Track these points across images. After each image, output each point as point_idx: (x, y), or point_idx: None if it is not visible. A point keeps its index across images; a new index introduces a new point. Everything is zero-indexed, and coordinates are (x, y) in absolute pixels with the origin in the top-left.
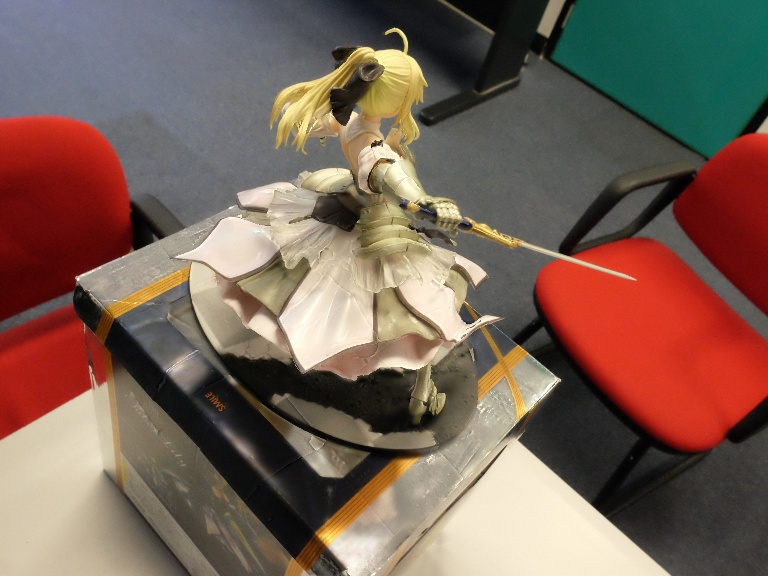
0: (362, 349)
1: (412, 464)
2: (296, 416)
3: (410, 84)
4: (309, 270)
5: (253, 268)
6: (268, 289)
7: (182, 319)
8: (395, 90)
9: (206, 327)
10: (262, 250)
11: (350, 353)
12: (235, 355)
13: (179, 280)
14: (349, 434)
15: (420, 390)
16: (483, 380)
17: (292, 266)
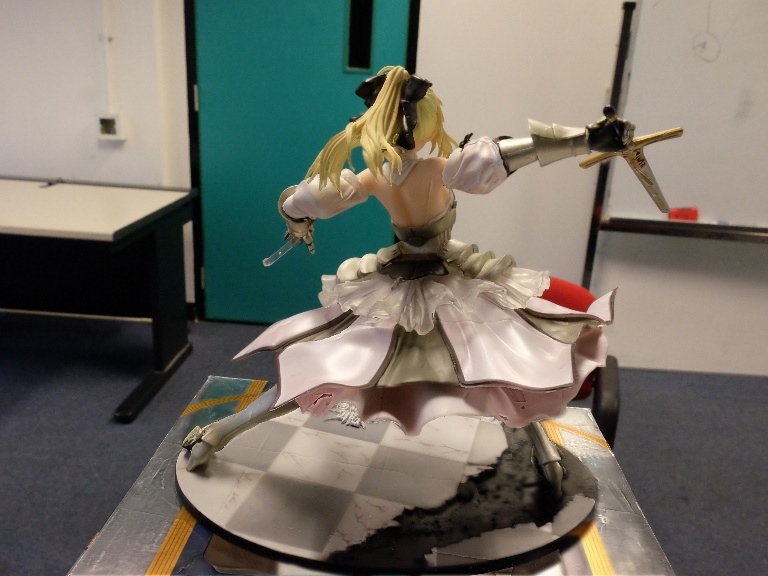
0: (439, 473)
1: (598, 533)
2: (467, 561)
3: (436, 101)
4: (441, 328)
5: (379, 363)
6: (418, 369)
7: (230, 566)
8: (433, 104)
9: (277, 546)
10: (369, 344)
11: (434, 482)
12: (340, 550)
13: (187, 527)
14: (528, 542)
15: (547, 452)
16: (549, 439)
17: (431, 326)
